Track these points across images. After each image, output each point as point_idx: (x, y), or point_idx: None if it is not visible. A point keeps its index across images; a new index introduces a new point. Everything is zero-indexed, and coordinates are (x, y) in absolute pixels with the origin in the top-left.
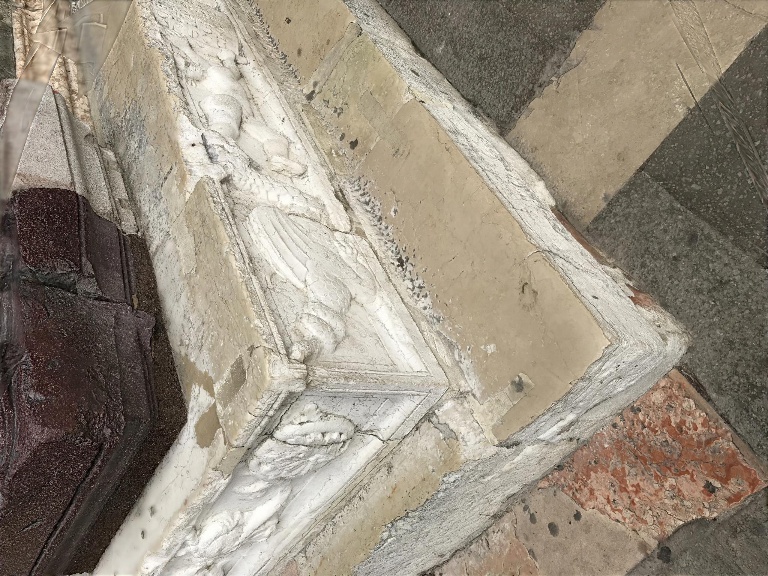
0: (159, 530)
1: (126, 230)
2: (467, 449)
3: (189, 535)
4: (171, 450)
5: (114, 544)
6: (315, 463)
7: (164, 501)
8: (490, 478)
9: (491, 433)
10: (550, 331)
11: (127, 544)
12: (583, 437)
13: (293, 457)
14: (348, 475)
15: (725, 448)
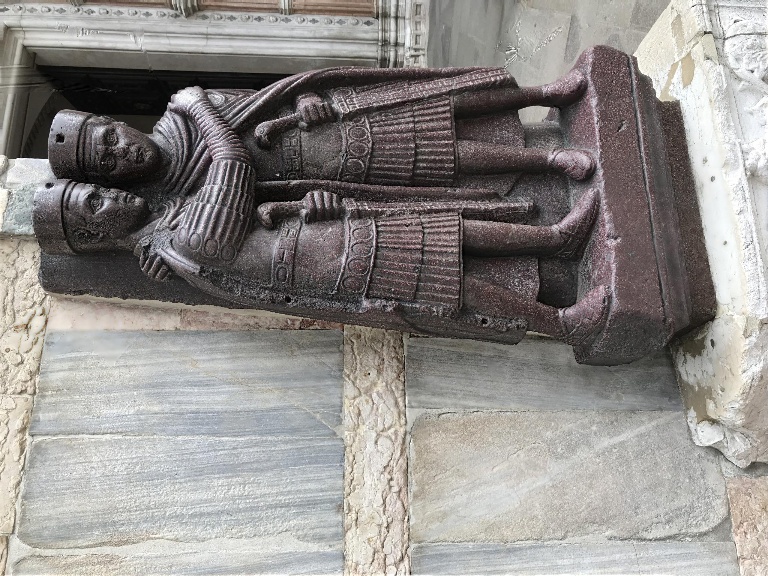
0: (715, 147)
1: None
2: None
3: None
4: (685, 125)
5: (709, 242)
6: None
7: (704, 138)
8: None
9: None
10: None
11: (713, 213)
12: None
13: (753, 46)
14: None
15: None
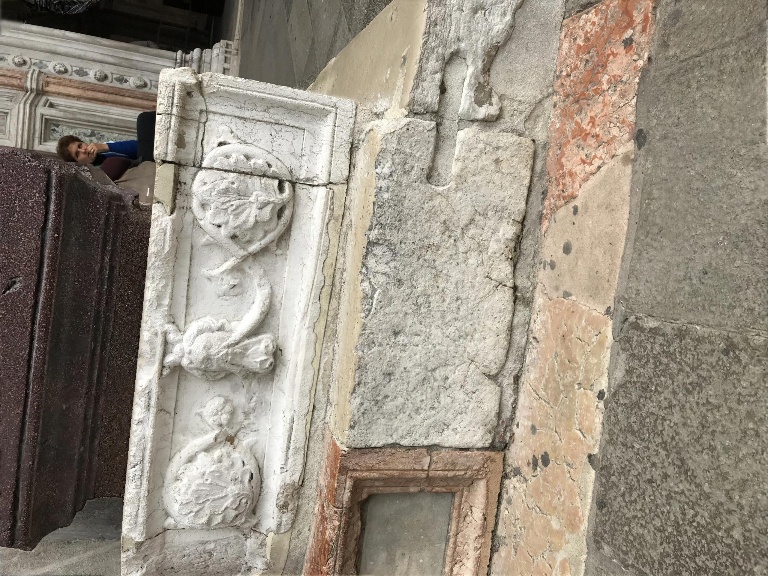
0: None
1: (142, 204)
2: (382, 129)
3: (169, 325)
4: None
5: None
6: (257, 204)
7: None
8: (446, 188)
9: (399, 110)
10: (406, 8)
11: None
12: (539, 140)
13: (228, 190)
14: (314, 246)
15: (616, 4)
